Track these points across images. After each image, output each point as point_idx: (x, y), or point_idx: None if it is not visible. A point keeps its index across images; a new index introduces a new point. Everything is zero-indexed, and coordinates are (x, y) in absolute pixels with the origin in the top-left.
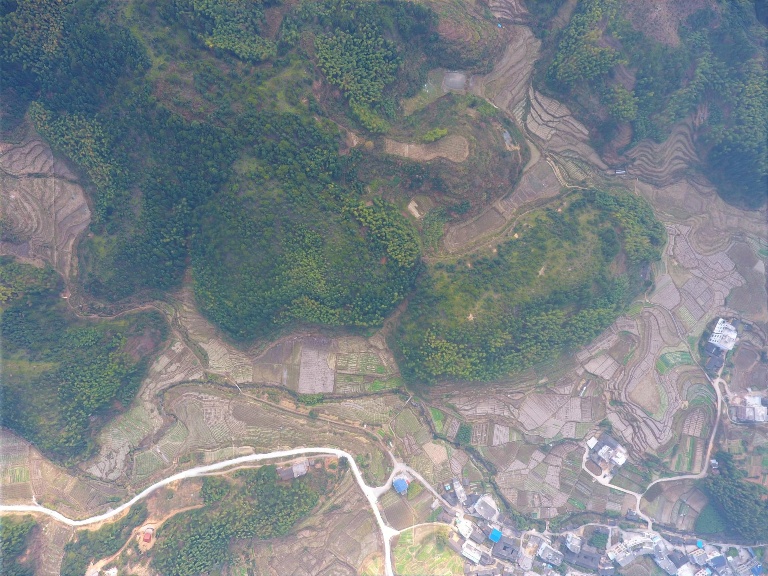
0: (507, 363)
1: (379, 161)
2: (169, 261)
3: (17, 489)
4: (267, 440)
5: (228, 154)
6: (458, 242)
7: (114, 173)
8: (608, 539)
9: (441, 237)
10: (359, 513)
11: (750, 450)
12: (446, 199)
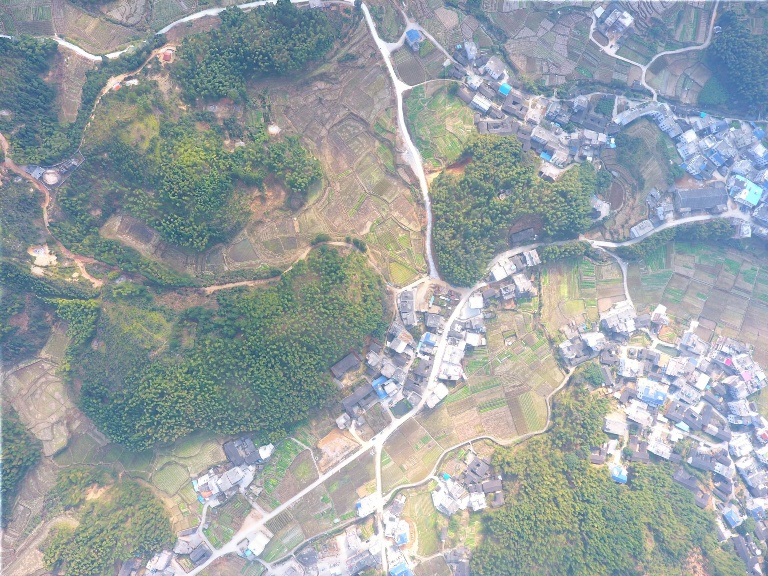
0: None
1: None
2: None
3: (40, 26)
4: None
5: None
6: None
7: None
8: (614, 106)
9: None
10: (372, 69)
11: (753, 12)
12: None
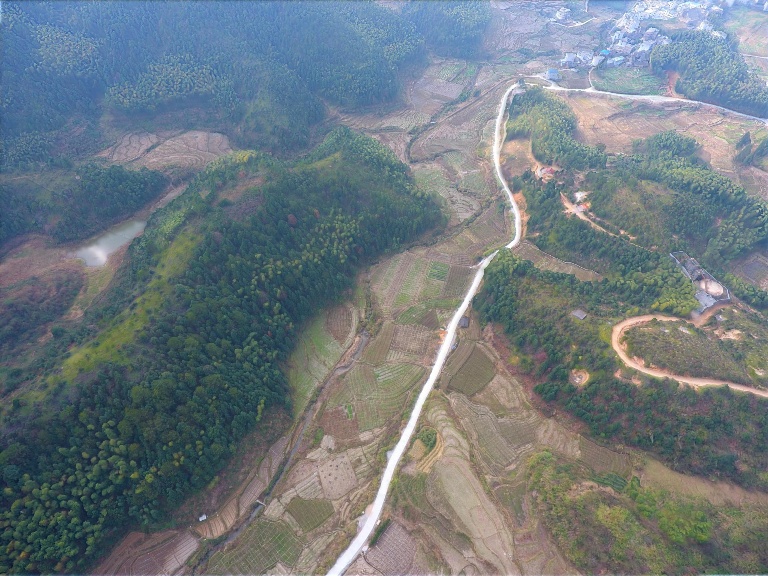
0: (484, 7)
1: None
2: None
3: (455, 277)
4: (487, 114)
5: None
6: None
7: (214, 66)
8: None
9: None
10: None
11: None
12: None
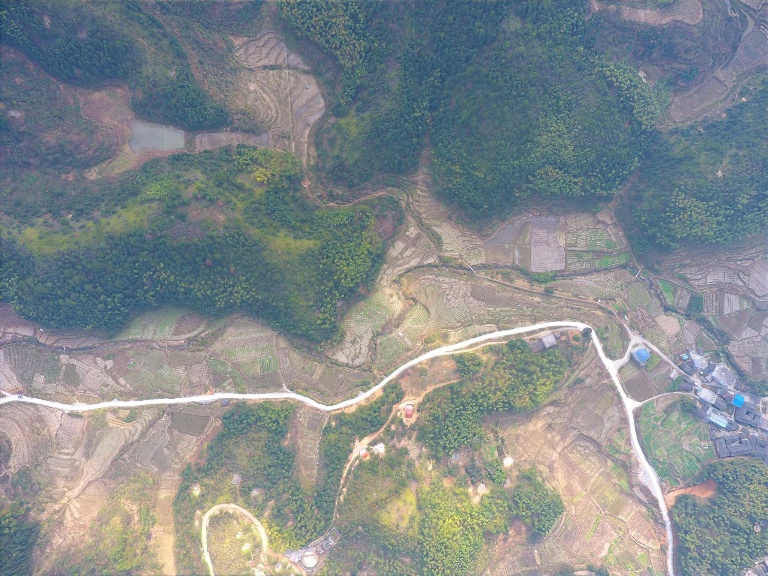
0: (749, 222)
1: (616, 28)
2: (415, 138)
3: (268, 378)
4: (507, 318)
5: (500, 11)
6: (682, 112)
7: (368, 49)
8: None
9: (668, 106)
10: (599, 387)
11: None
12: (676, 66)
